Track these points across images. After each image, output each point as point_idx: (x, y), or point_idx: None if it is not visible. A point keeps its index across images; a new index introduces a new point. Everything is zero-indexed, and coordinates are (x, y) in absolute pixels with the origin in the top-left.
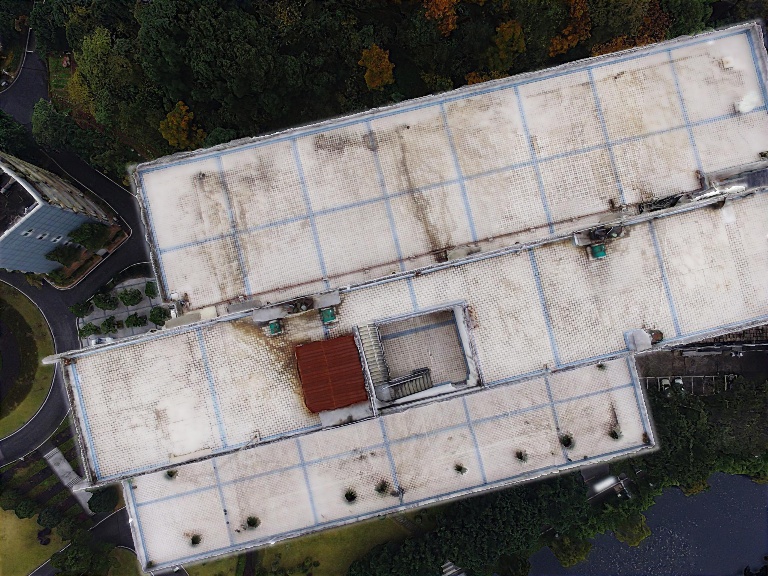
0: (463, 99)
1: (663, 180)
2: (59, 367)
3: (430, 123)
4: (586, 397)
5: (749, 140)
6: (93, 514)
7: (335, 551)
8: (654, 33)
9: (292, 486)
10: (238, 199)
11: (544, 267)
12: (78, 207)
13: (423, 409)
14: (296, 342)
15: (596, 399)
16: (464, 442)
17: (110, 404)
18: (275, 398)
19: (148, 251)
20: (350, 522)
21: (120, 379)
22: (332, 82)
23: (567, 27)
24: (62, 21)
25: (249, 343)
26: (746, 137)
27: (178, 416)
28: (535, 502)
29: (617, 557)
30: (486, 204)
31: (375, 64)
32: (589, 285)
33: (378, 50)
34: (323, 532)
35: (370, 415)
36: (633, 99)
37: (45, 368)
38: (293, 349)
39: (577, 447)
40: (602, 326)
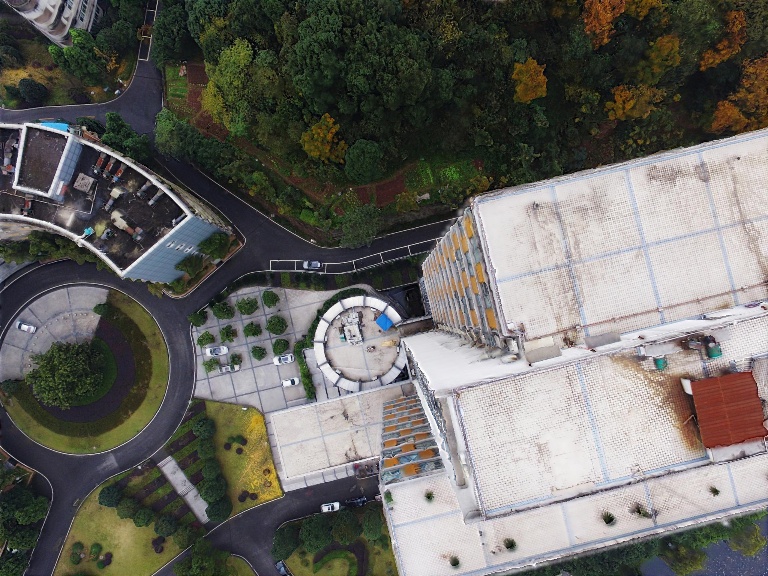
0: None
1: None
2: (173, 375)
3: (760, 154)
4: None
5: None
6: (205, 522)
7: None
8: None
9: (546, 508)
10: (572, 229)
11: None
12: None
13: None
14: (674, 376)
15: None
16: None
17: (493, 437)
18: (654, 432)
19: (262, 260)
20: None
21: (502, 413)
22: (474, 94)
23: (722, 42)
24: (197, 31)
25: (627, 377)
26: None
27: (559, 449)
28: None
29: (723, 566)
30: None
31: (532, 78)
32: None
33: (535, 64)
34: None
35: (762, 450)
36: None
37: (159, 376)
38: (672, 383)
39: None
40: None
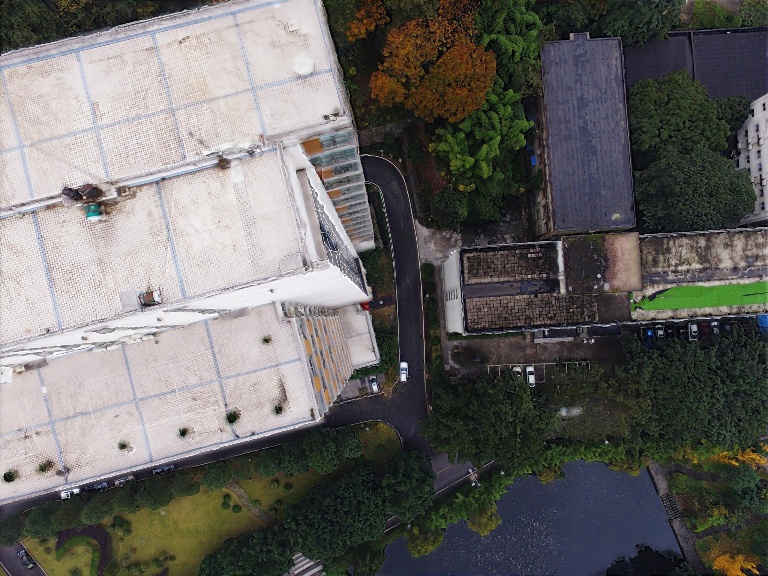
0: (24, 66)
1: (227, 145)
2: None
3: None
4: (254, 373)
5: (314, 103)
6: None
7: (191, 545)
8: (456, 16)
9: None
10: None
11: (47, 230)
12: None
13: (89, 387)
14: None
15: (264, 375)
16: (130, 420)
17: None
18: None
19: None
20: (5, 502)
21: None
22: None
23: (360, 11)
24: None
25: None
26: (311, 100)
27: None
28: (379, 492)
29: (478, 547)
30: (46, 171)
31: None
32: (93, 247)
33: None
34: (178, 526)
35: None
36: (198, 63)
37: None
38: None
39: (245, 423)
40: (106, 289)
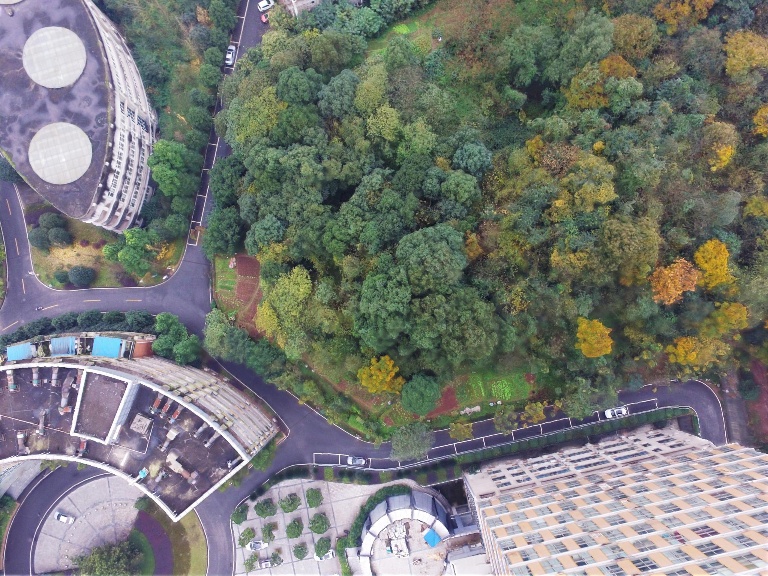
0: None
1: None
2: (211, 568)
3: None
4: None
5: None
6: None
7: None
8: None
9: None
10: None
11: None
12: (258, 432)
13: None
14: None
15: None
16: None
17: None
18: None
19: (306, 452)
20: None
21: None
22: None
23: None
24: (254, 252)
25: None
26: None
27: None
28: None
29: None
30: None
31: (597, 341)
32: None
33: (602, 328)
34: None
35: None
36: None
37: (197, 570)
38: None
39: None
40: None
